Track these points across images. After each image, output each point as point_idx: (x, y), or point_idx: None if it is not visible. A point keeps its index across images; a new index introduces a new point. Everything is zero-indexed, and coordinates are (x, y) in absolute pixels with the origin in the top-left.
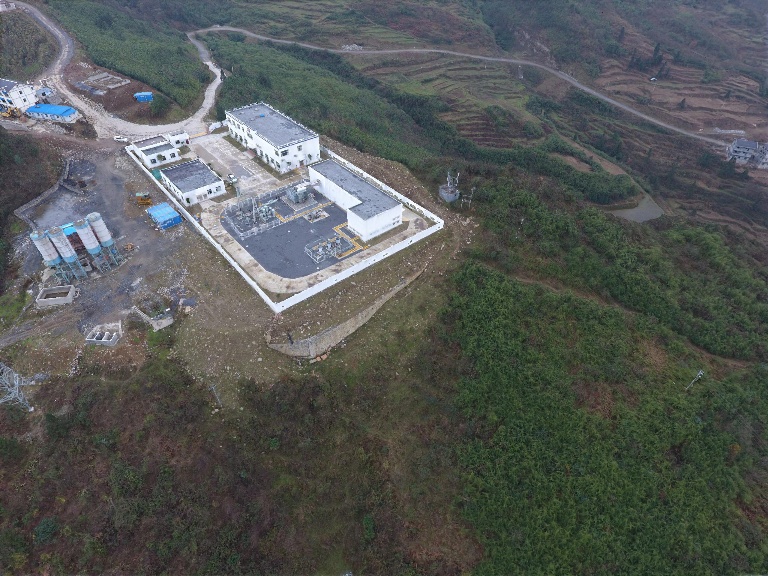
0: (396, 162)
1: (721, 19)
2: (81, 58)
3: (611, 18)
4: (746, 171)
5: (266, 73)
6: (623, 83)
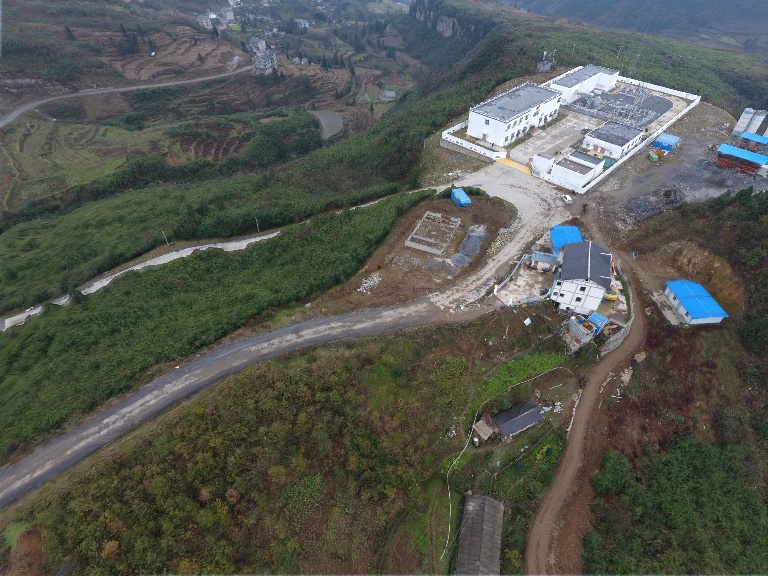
0: (509, 81)
1: (44, 1)
2: (339, 295)
3: (24, 25)
4: (282, 73)
5: (88, 249)
6: (140, 69)
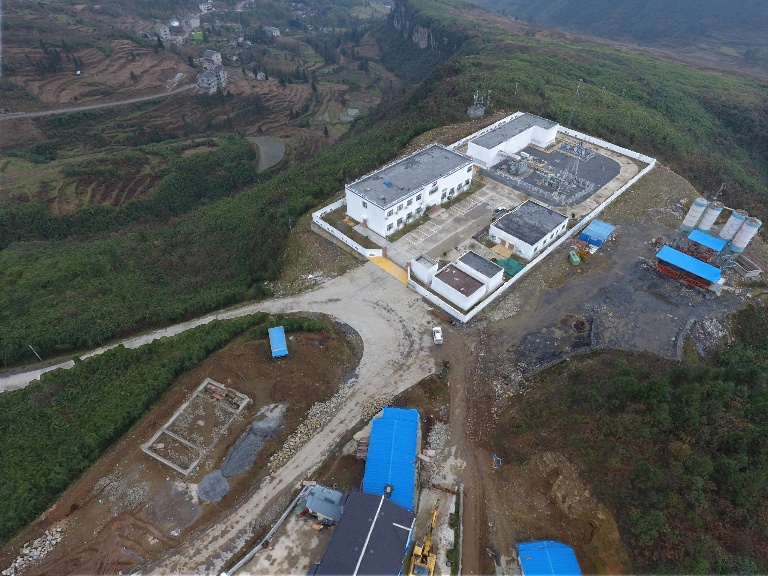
0: (428, 132)
1: None
2: None
3: None
4: (229, 91)
5: None
6: (61, 90)
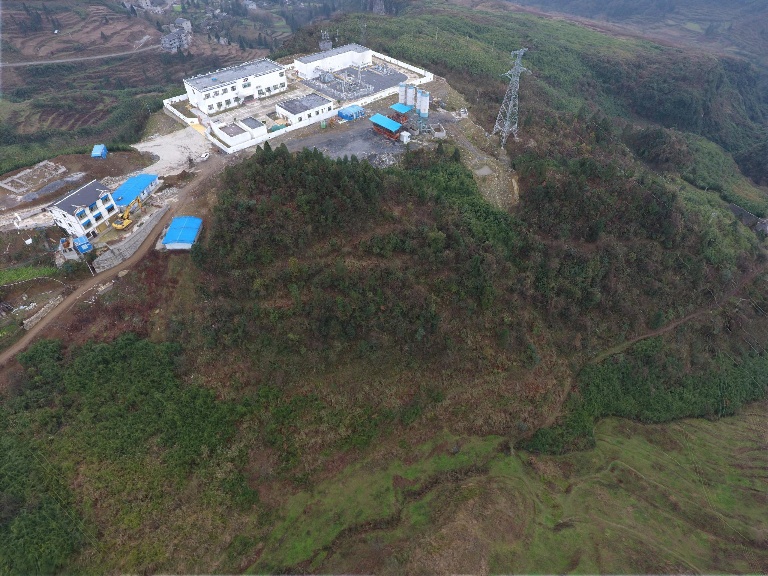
0: (280, 58)
1: None
2: None
3: None
4: (189, 52)
5: None
6: (41, 46)
